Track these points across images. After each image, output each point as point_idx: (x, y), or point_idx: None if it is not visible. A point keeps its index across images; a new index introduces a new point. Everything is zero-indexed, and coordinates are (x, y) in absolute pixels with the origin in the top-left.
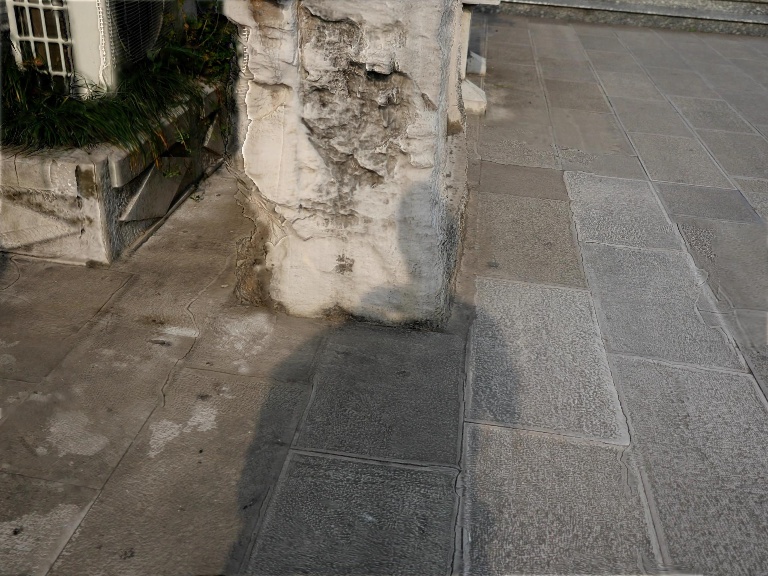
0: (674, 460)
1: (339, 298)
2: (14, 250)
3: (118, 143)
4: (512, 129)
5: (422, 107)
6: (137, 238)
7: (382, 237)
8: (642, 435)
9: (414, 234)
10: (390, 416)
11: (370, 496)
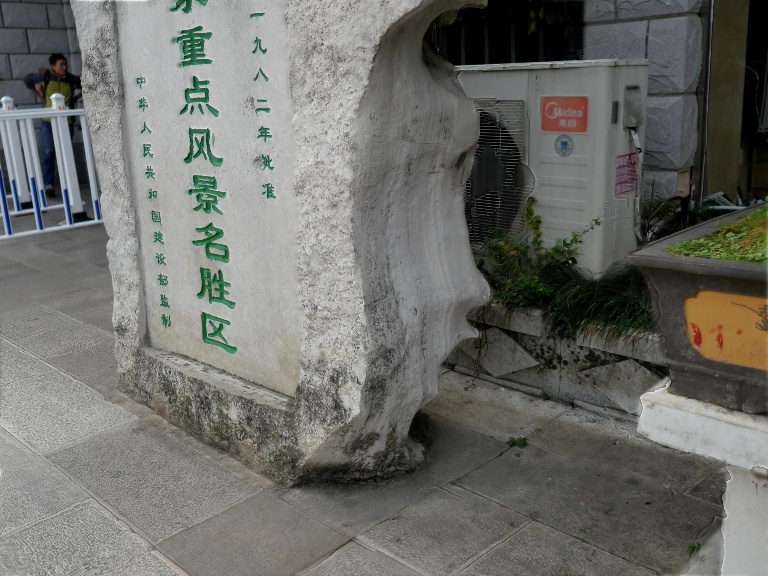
0: None
1: None
2: None
3: None
4: None
5: None
6: None
7: None
8: None
9: None
10: None
11: None
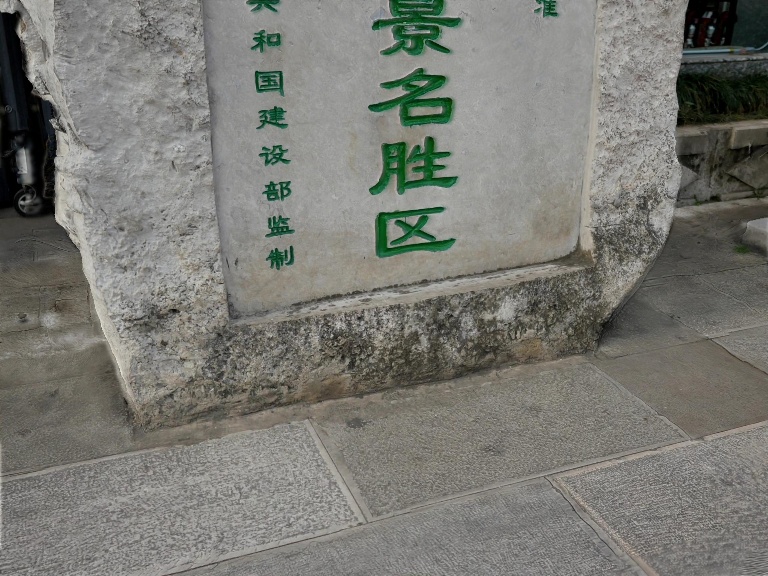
0: None
1: None
2: None
3: None
4: None
5: (70, 139)
6: None
7: None
8: None
9: None
10: None
11: None
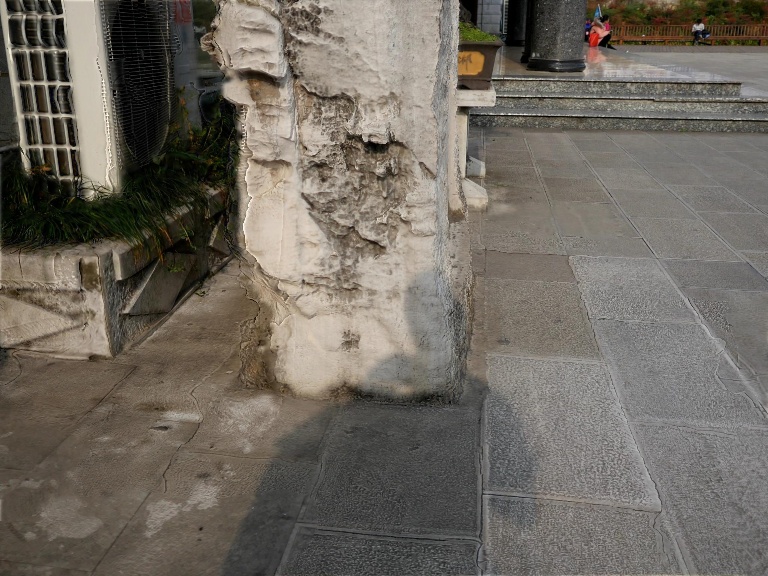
0: (711, 525)
1: (347, 378)
2: (16, 346)
3: (123, 237)
4: (514, 222)
5: (420, 175)
6: (142, 332)
7: (387, 310)
8: (674, 501)
9: (419, 305)
10: (404, 491)
11: (385, 573)
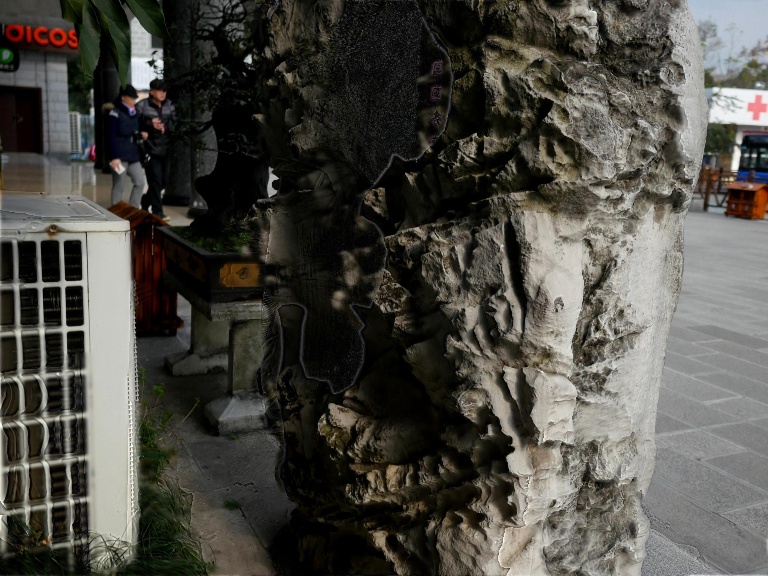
0: None
1: None
2: None
3: None
4: None
5: (639, 503)
6: None
7: None
8: None
9: None
10: None
11: None
